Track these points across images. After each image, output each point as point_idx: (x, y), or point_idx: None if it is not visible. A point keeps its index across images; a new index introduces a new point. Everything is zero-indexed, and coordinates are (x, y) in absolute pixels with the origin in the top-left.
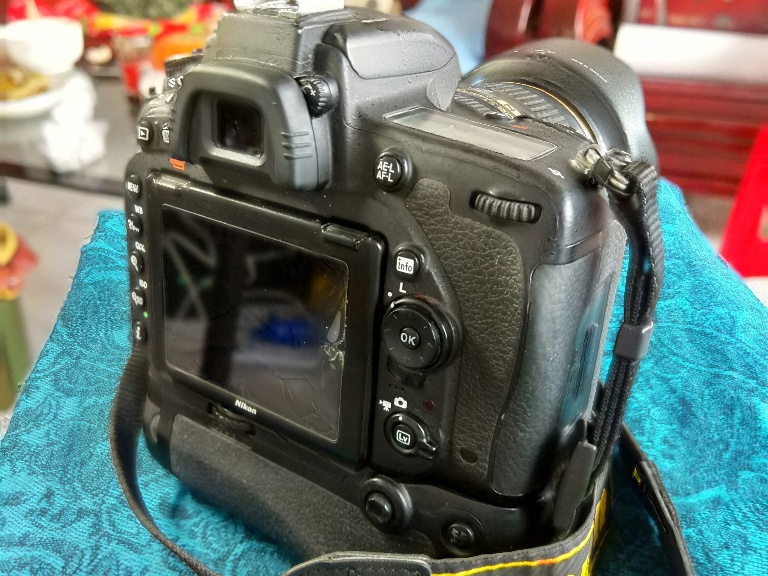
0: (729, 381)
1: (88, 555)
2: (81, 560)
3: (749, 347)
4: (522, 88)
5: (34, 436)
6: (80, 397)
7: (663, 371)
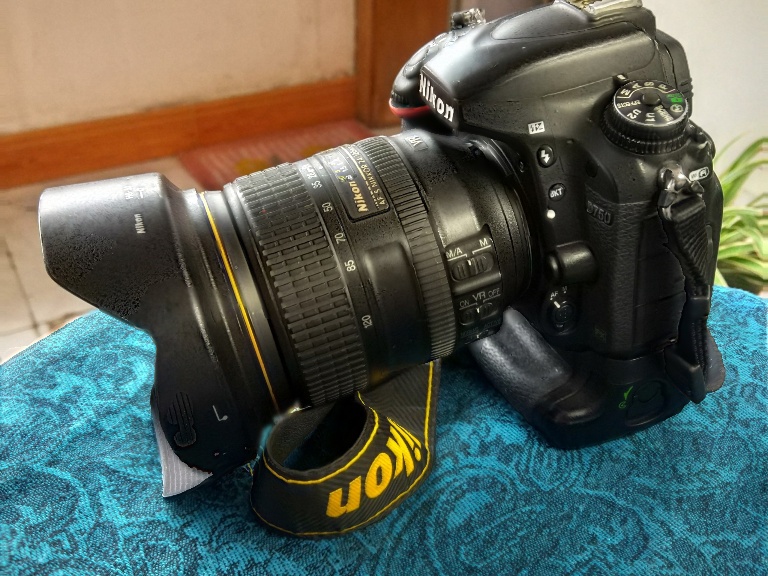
0: None
1: (738, 391)
2: (743, 391)
3: None
4: (236, 186)
5: None
6: (762, 553)
7: None
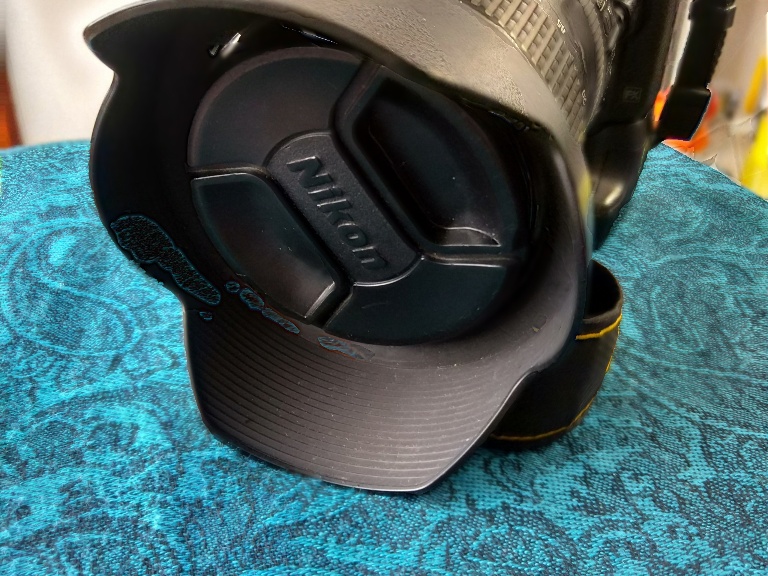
0: (73, 279)
1: None
2: None
3: (6, 320)
4: None
5: (767, 211)
6: None
7: (147, 293)
